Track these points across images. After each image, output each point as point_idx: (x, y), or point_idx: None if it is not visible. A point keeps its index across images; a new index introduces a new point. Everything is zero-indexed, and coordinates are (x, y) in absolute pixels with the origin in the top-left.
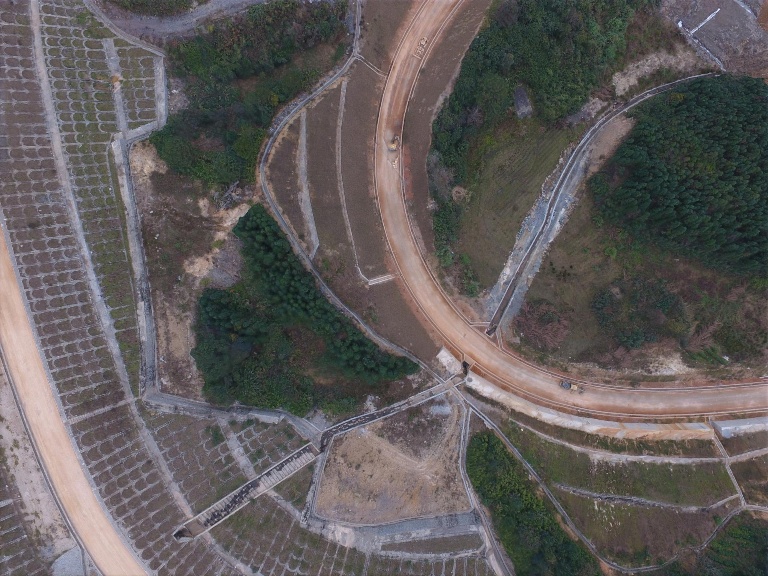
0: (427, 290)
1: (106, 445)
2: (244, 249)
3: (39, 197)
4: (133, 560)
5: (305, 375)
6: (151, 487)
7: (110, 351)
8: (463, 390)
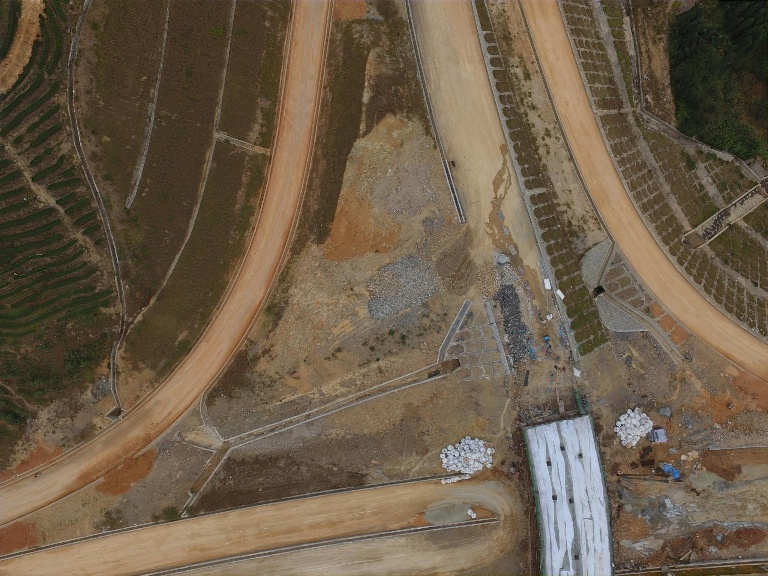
0: None
1: (622, 144)
2: None
3: None
4: (661, 255)
5: (740, 123)
6: (656, 194)
7: (609, 59)
8: None
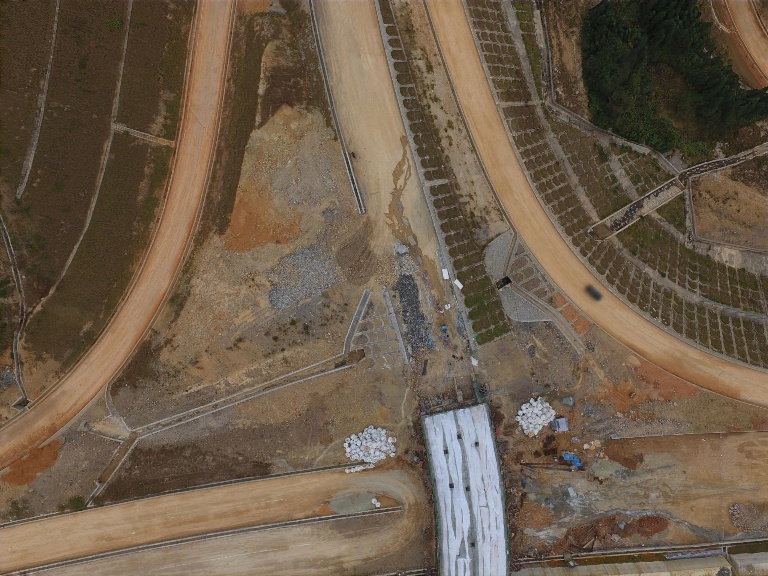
0: (761, 47)
1: (527, 136)
2: None
3: None
4: (564, 246)
5: None
6: (563, 186)
7: (517, 52)
8: None
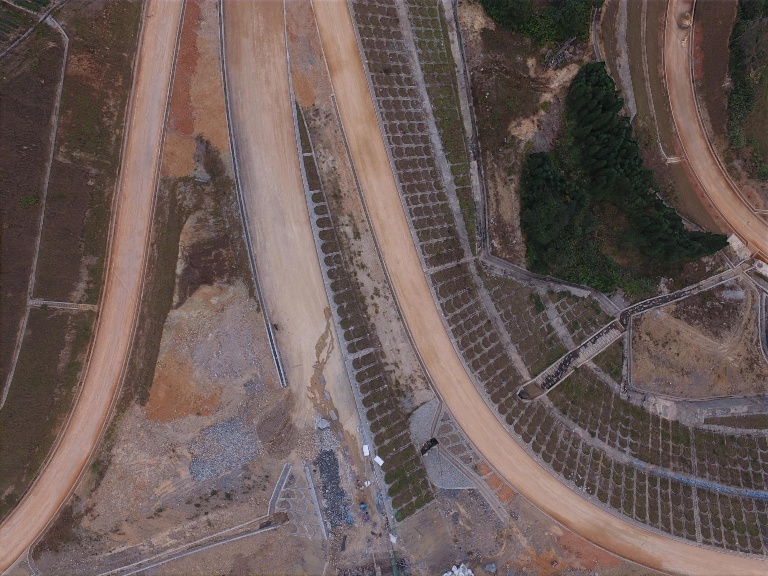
0: (711, 175)
1: (457, 299)
2: (567, 113)
3: (389, 44)
4: (490, 414)
5: (603, 253)
6: (494, 346)
7: (451, 207)
8: (754, 275)
